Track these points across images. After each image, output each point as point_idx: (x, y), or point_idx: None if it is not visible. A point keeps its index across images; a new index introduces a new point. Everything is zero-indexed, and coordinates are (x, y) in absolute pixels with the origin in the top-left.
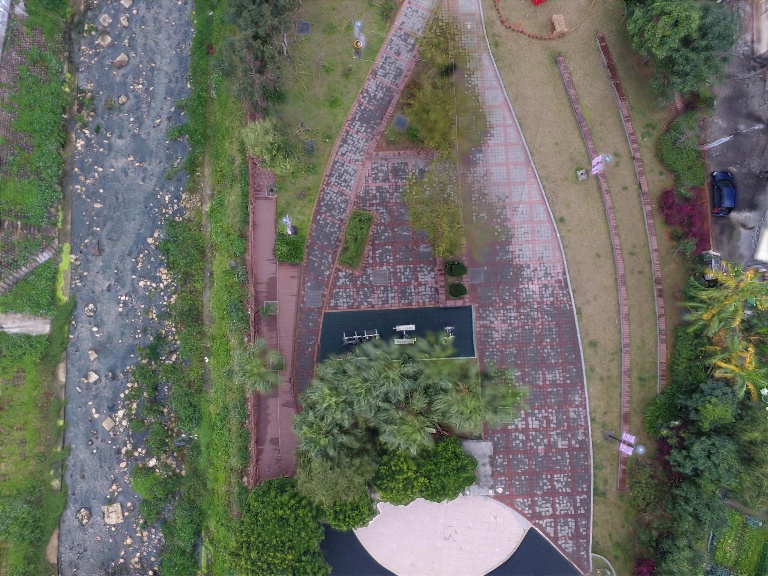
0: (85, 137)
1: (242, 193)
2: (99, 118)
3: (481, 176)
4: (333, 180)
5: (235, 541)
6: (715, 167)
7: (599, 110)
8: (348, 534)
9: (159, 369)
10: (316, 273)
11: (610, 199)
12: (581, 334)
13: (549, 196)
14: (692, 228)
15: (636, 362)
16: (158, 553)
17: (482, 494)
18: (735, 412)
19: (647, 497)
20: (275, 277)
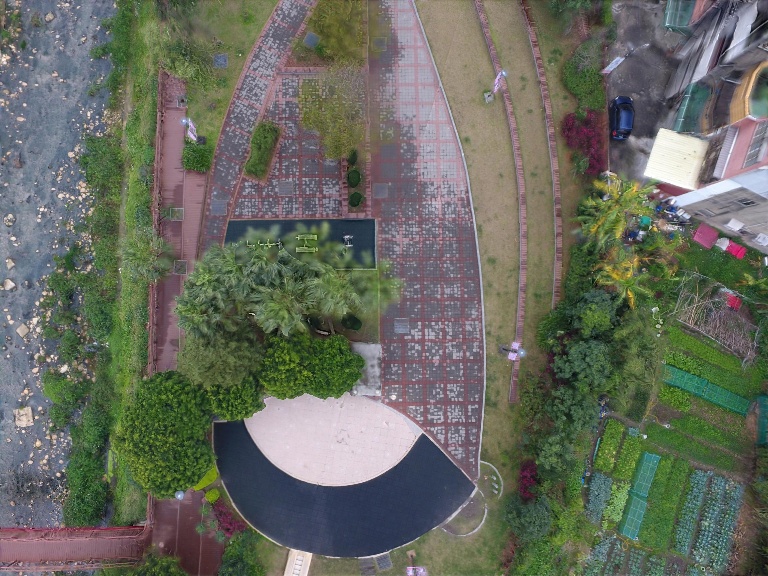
0: (11, 52)
1: (153, 102)
2: (26, 34)
3: (390, 95)
4: (244, 94)
5: (121, 426)
6: (619, 93)
7: (509, 34)
8: (242, 434)
9: (74, 278)
10: (223, 183)
11: (515, 121)
12: (480, 250)
13: (456, 116)
14: (591, 149)
15: (532, 279)
16: (66, 456)
17: (369, 394)
18: (614, 319)
19: (534, 406)
20: (182, 185)
